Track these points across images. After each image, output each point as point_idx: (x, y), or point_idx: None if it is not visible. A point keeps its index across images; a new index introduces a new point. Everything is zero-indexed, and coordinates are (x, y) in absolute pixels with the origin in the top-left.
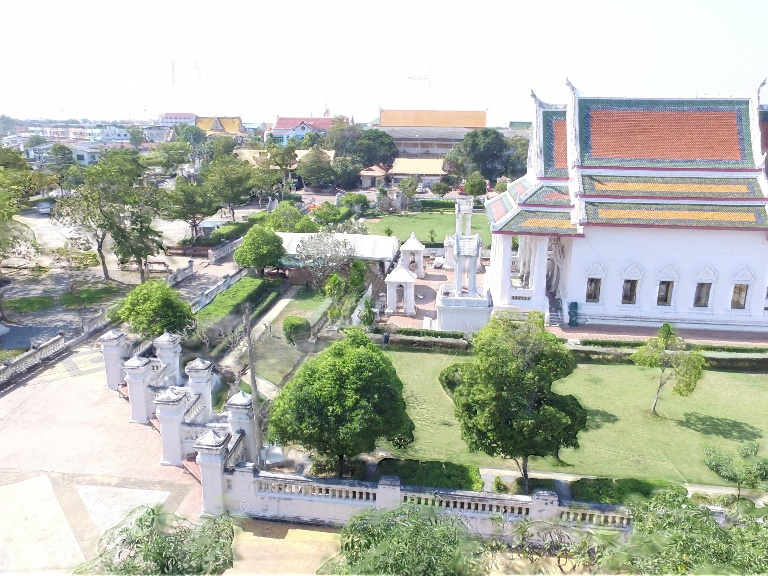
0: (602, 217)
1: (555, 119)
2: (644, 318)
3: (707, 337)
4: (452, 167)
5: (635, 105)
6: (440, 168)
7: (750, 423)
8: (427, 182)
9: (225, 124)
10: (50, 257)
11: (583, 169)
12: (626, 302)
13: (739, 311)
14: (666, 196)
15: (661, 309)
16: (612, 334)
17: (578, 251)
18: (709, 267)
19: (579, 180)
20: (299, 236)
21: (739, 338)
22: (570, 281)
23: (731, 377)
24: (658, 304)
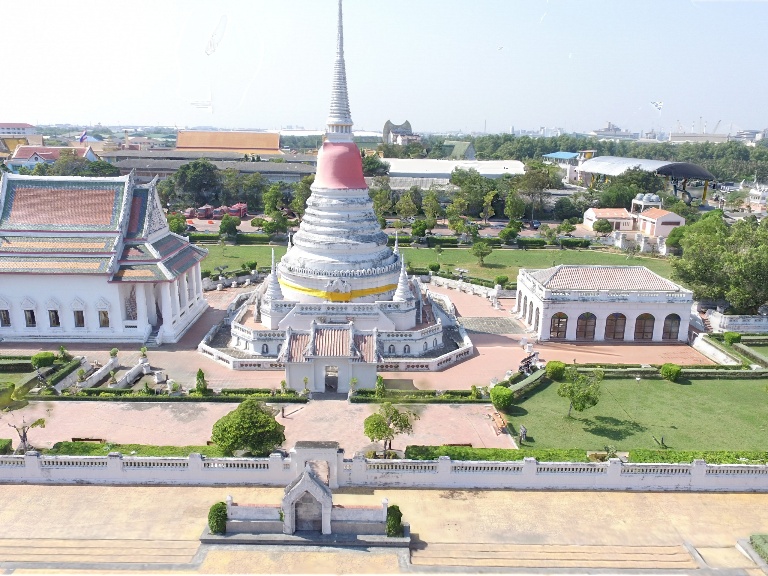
0: None
1: None
2: (42, 336)
3: (71, 348)
4: None
5: (48, 185)
6: None
7: None
8: None
9: (10, 145)
10: None
11: None
12: (30, 325)
13: (105, 329)
14: (46, 252)
15: (53, 330)
16: (5, 349)
17: None
18: (77, 300)
19: None
20: None
21: (93, 348)
22: None
23: None
24: (52, 326)
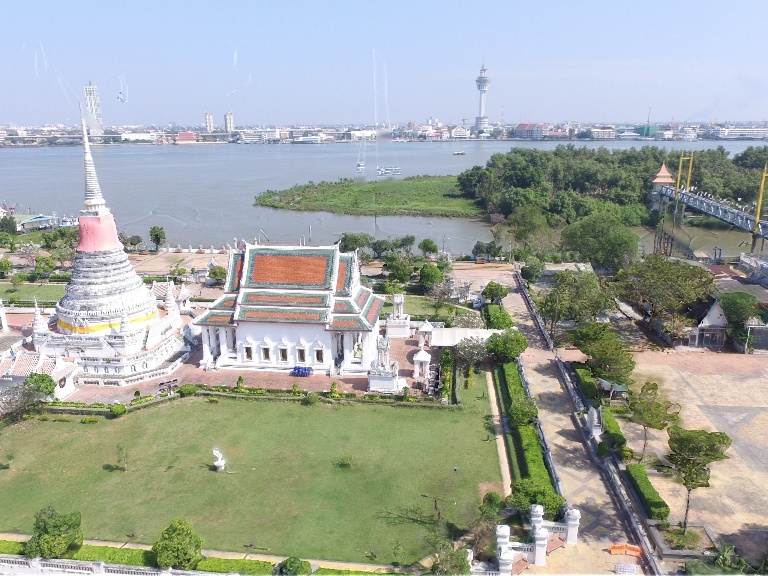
0: None
1: None
2: None
3: None
4: None
5: None
6: None
7: None
8: None
9: None
10: (672, 360)
11: None
12: None
13: None
14: None
15: None
16: None
17: None
18: None
19: None
20: (490, 329)
21: None
22: None
23: None
24: None
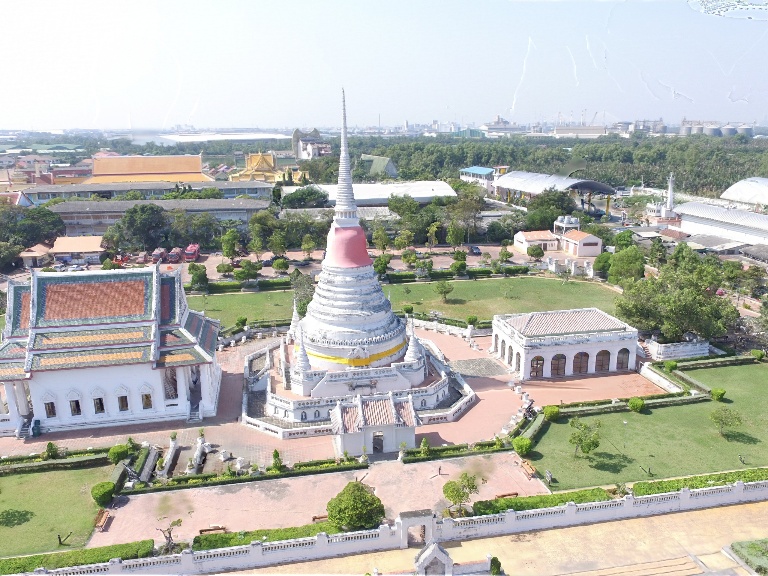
0: (42, 365)
1: (23, 292)
2: (88, 423)
3: (121, 432)
4: (110, 244)
5: (78, 280)
6: (98, 245)
7: (36, 511)
8: (87, 258)
9: None
10: None
11: (37, 329)
12: (76, 414)
13: (148, 410)
14: (88, 345)
15: (98, 416)
16: (57, 440)
17: (33, 387)
18: (121, 387)
19: (32, 338)
20: None
21: (142, 430)
22: (33, 406)
23: (73, 474)
24: (97, 413)
